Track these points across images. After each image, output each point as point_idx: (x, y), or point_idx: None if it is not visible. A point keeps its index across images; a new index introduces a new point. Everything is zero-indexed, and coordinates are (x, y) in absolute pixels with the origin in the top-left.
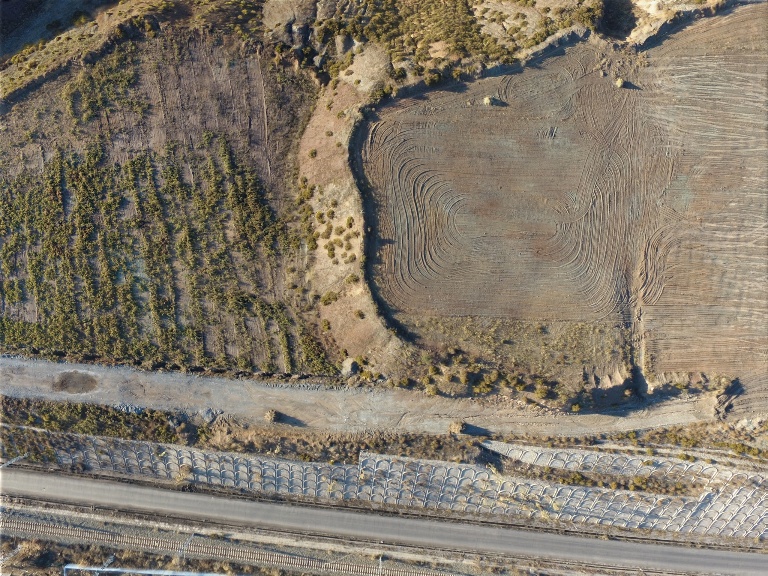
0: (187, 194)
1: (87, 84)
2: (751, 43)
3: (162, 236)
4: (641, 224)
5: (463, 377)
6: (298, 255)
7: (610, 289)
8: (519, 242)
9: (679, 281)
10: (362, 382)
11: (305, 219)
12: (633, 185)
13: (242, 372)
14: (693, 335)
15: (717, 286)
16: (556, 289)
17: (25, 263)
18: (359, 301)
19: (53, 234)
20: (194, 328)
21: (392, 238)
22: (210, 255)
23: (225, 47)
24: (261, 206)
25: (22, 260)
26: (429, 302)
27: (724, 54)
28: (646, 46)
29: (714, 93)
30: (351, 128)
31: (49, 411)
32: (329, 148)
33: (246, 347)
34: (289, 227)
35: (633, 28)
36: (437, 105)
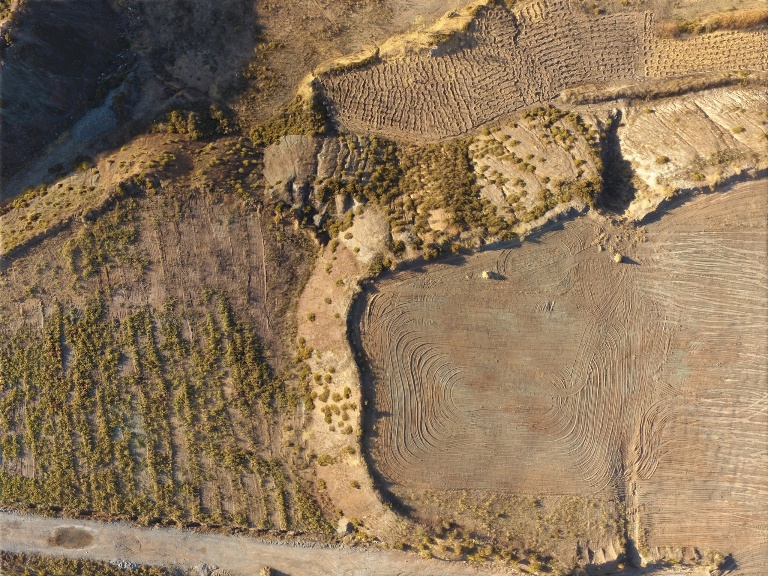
0: (186, 351)
1: (88, 241)
2: (749, 220)
3: (160, 392)
4: (637, 398)
5: (457, 550)
6: (295, 414)
7: (605, 463)
8: (515, 416)
9: (674, 456)
10: (357, 542)
11: (303, 378)
12: (629, 360)
13: (238, 528)
14: (687, 510)
15: (712, 461)
16: (551, 463)
17: (23, 418)
18: (355, 472)
19: (52, 390)
20: (191, 484)
21: (389, 411)
22: (208, 412)
23: (225, 205)
24: (259, 364)
25: (20, 415)
26: (425, 475)
27: (722, 231)
28: (644, 221)
29: (711, 269)
30: (349, 301)
31: (45, 566)
32: (327, 316)
33: (242, 503)
34: (287, 385)
35: (632, 200)
36: (435, 278)
